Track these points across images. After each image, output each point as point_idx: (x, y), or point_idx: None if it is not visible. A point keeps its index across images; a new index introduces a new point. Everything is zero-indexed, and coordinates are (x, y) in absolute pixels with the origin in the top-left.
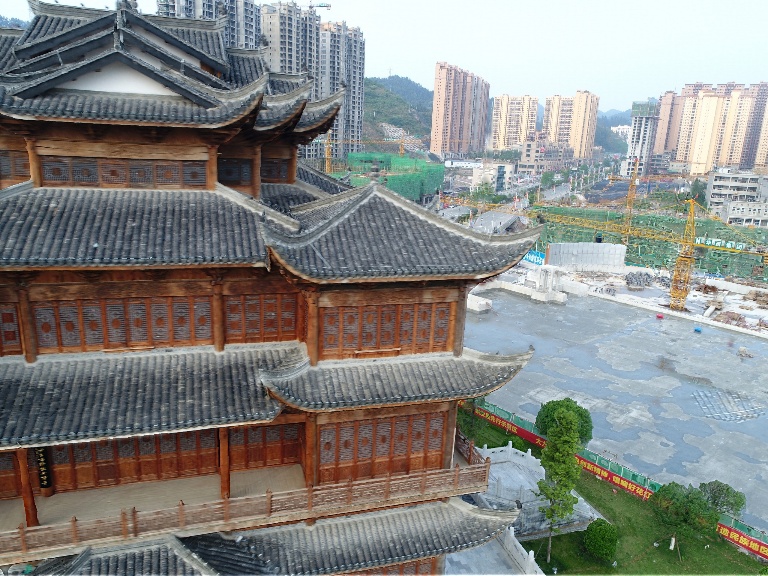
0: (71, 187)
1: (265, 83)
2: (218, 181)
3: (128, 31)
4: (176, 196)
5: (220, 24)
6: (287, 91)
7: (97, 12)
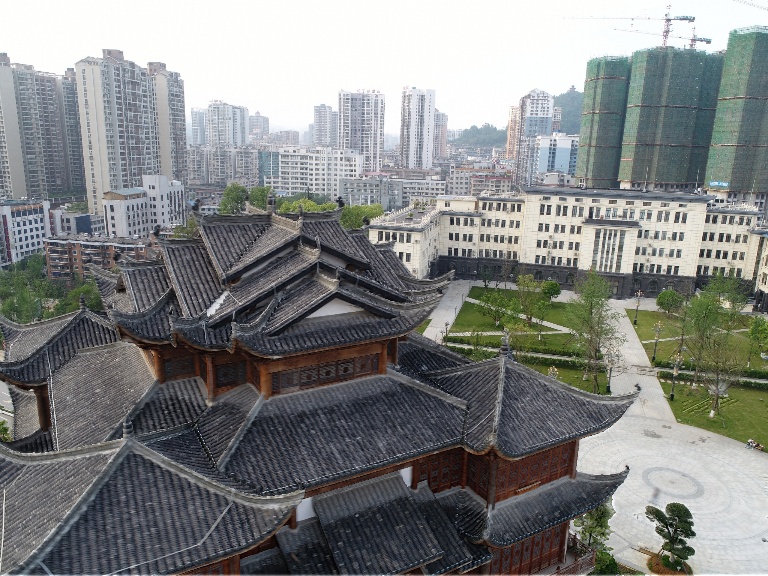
0: (141, 349)
1: (111, 317)
2: (201, 374)
3: (162, 251)
4: (144, 378)
5: (298, 225)
6: (300, 300)
7: (261, 213)
